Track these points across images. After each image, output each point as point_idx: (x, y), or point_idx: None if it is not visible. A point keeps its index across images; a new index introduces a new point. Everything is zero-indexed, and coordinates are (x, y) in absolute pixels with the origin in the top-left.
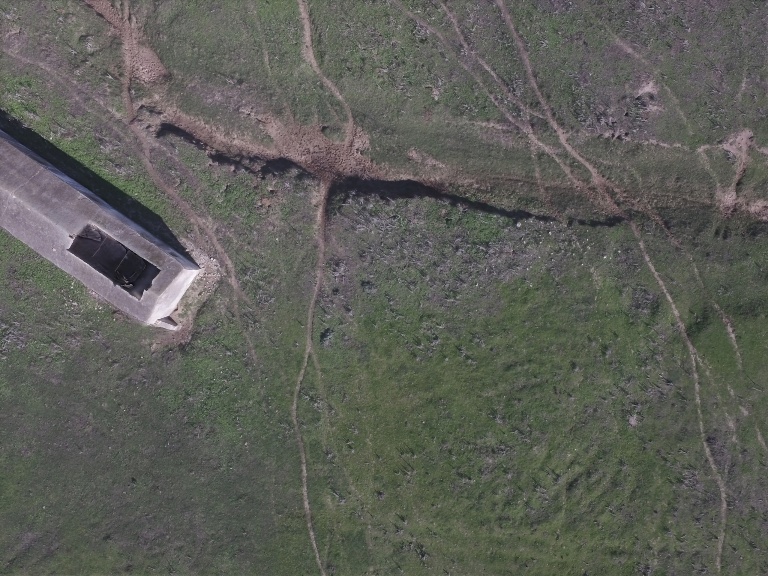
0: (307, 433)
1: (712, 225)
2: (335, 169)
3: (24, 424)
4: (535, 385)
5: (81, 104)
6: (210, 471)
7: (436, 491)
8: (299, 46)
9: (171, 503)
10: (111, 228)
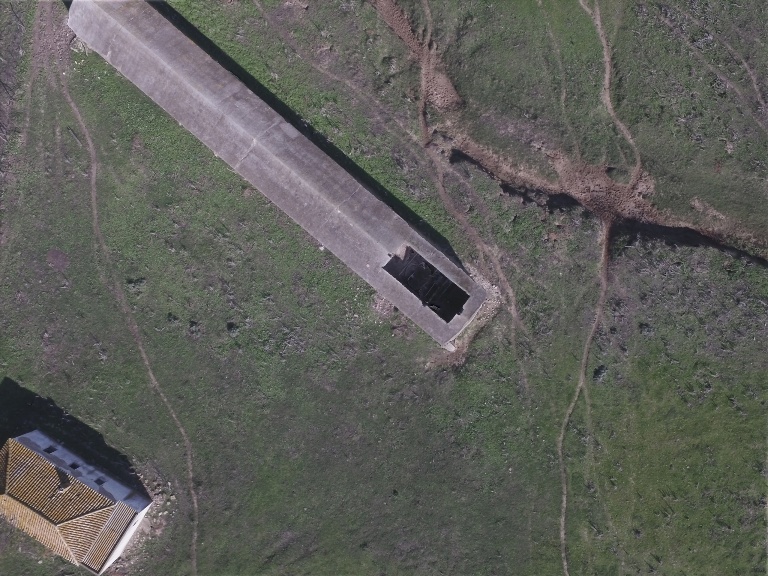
0: (571, 465)
1: None
2: (614, 209)
3: (295, 426)
4: None
5: (382, 124)
6: (473, 492)
7: (694, 536)
8: (598, 88)
9: (430, 519)
10: (424, 250)
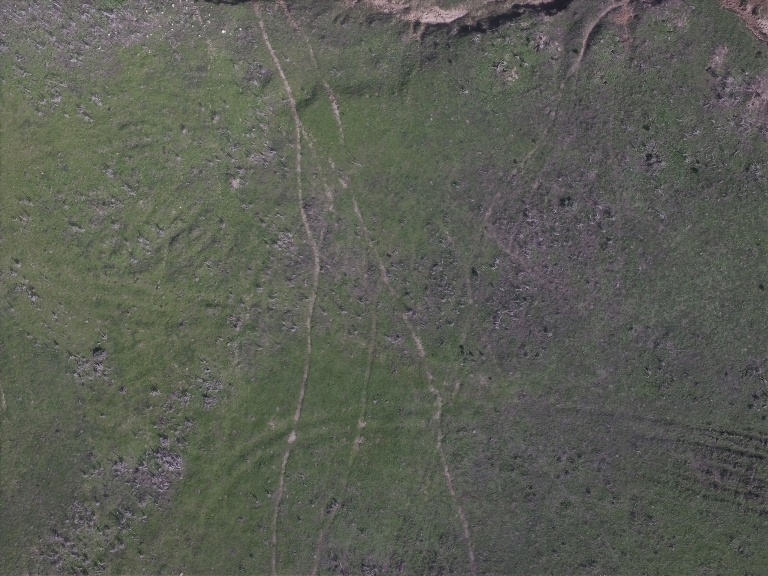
0: None
1: (331, 11)
2: None
3: None
4: (147, 145)
5: None
6: None
7: (49, 238)
8: None
9: None
10: None
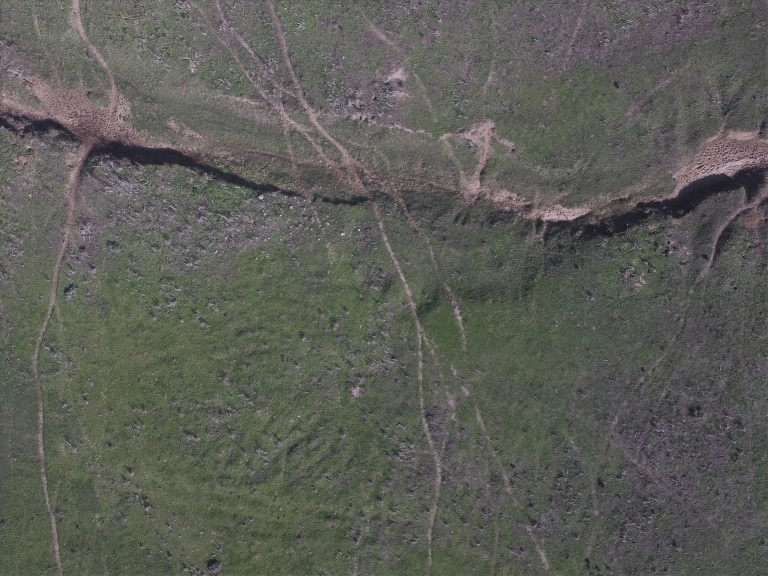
0: (46, 382)
1: (452, 211)
2: (99, 133)
3: None
4: (264, 352)
5: None
6: None
7: (163, 446)
8: (66, 12)
9: None
10: None
